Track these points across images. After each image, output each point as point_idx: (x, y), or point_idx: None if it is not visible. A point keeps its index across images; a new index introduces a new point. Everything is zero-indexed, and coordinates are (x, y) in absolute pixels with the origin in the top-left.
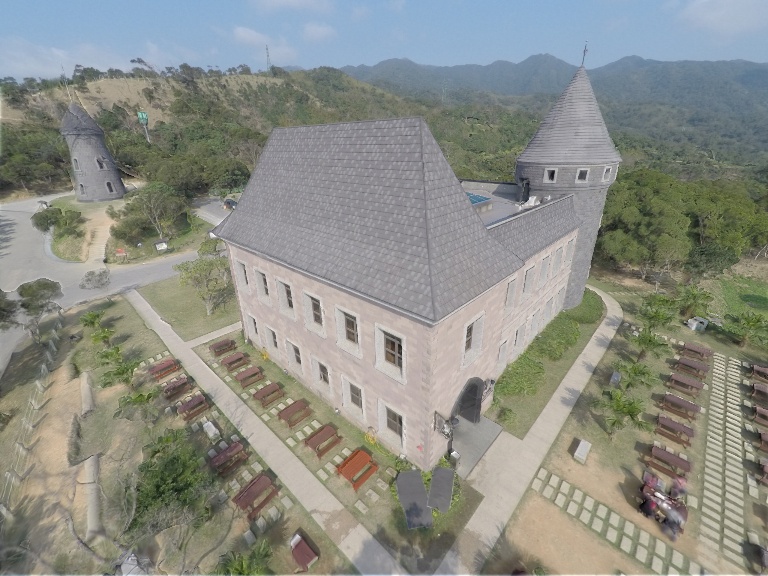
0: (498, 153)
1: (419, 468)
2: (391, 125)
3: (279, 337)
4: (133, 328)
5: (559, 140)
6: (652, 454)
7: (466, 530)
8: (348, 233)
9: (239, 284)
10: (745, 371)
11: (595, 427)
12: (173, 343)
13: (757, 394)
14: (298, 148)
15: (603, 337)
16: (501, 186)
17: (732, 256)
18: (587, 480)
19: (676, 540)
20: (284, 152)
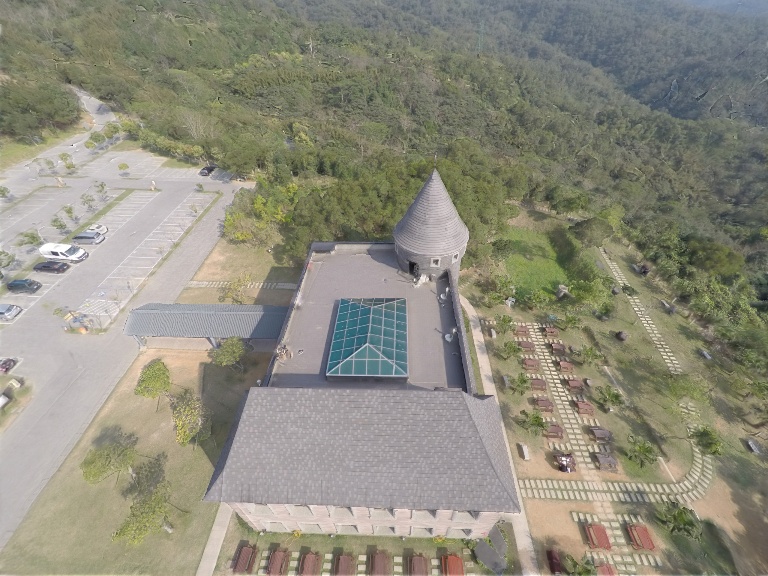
0: (236, 68)
1: (481, 538)
2: (433, 396)
3: (323, 524)
4: None
5: (436, 236)
6: (548, 432)
7: (520, 551)
8: (416, 470)
9: (251, 512)
10: (542, 331)
11: (518, 428)
12: None
13: (555, 351)
14: (313, 409)
15: (480, 343)
16: (374, 246)
17: (511, 246)
18: (536, 469)
19: (575, 475)
20: (289, 412)
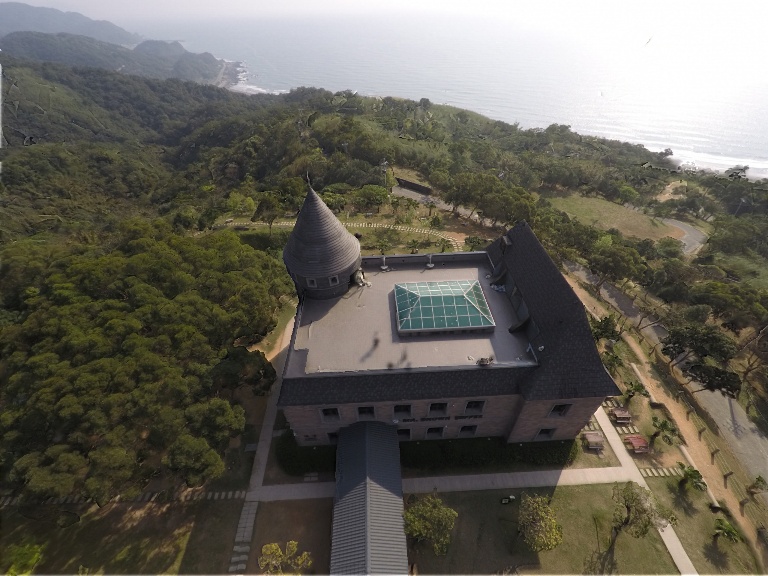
0: None
1: None
2: None
3: None
4: (711, 575)
5: None
6: None
7: None
8: None
9: None
10: None
11: None
12: (642, 485)
13: None
14: None
15: None
16: None
17: None
18: None
19: None
20: None
